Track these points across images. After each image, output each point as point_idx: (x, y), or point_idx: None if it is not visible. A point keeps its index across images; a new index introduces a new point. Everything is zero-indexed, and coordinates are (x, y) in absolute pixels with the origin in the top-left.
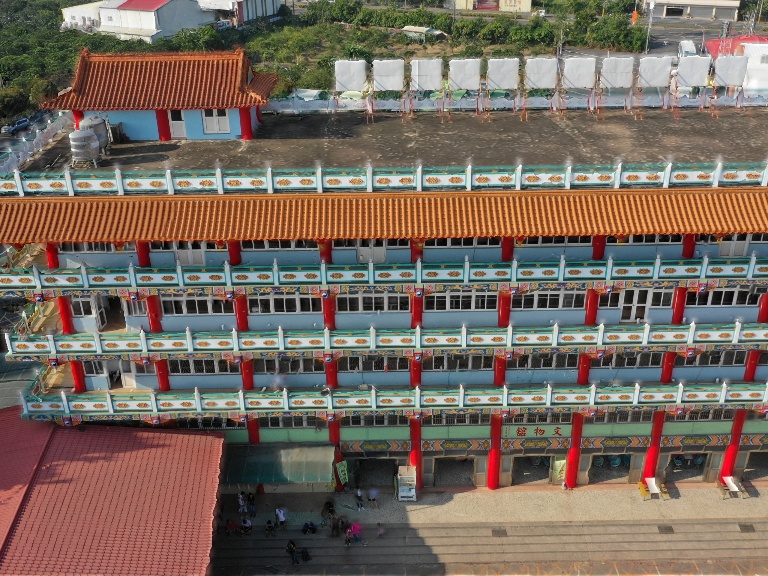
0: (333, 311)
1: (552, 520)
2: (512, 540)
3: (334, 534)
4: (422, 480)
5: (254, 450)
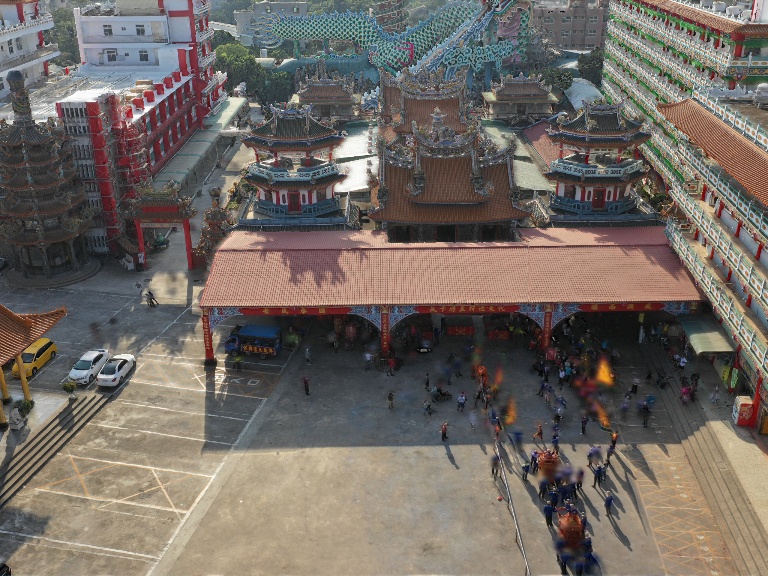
0: (762, 245)
1: (747, 492)
2: (716, 472)
3: (684, 391)
4: (755, 421)
5: (712, 323)
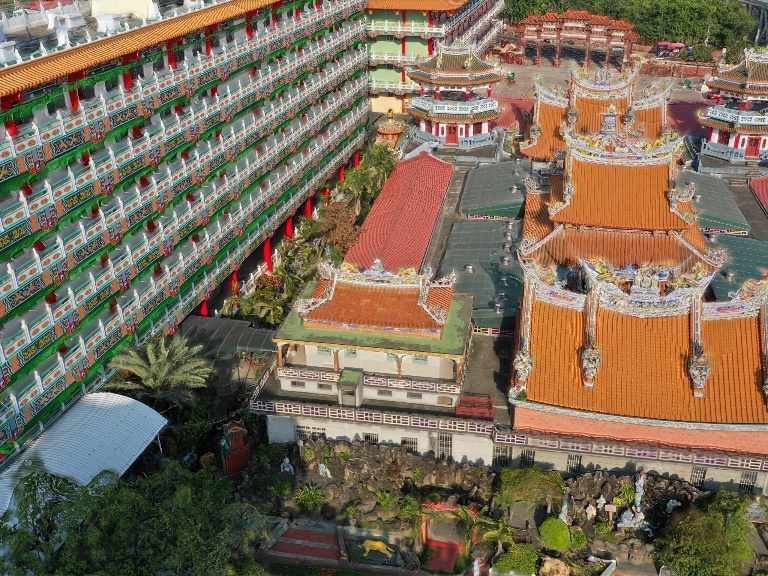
0: None
1: None
2: None
3: None
4: None
5: None
